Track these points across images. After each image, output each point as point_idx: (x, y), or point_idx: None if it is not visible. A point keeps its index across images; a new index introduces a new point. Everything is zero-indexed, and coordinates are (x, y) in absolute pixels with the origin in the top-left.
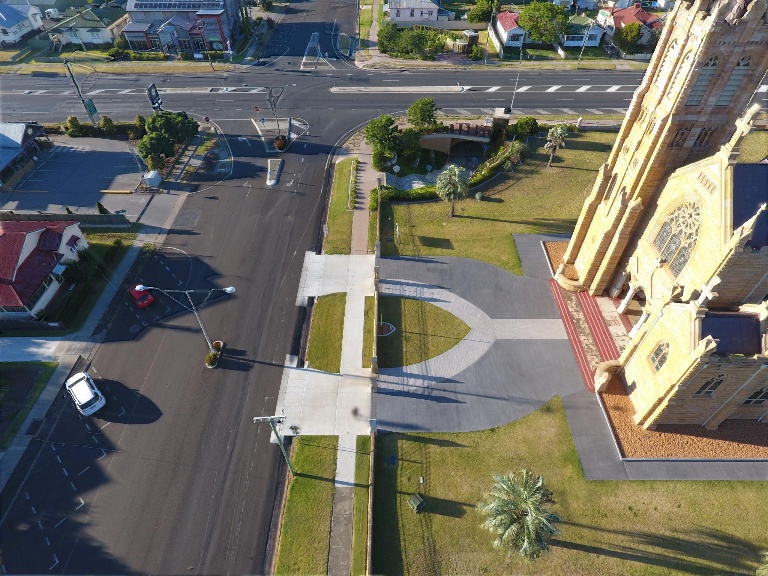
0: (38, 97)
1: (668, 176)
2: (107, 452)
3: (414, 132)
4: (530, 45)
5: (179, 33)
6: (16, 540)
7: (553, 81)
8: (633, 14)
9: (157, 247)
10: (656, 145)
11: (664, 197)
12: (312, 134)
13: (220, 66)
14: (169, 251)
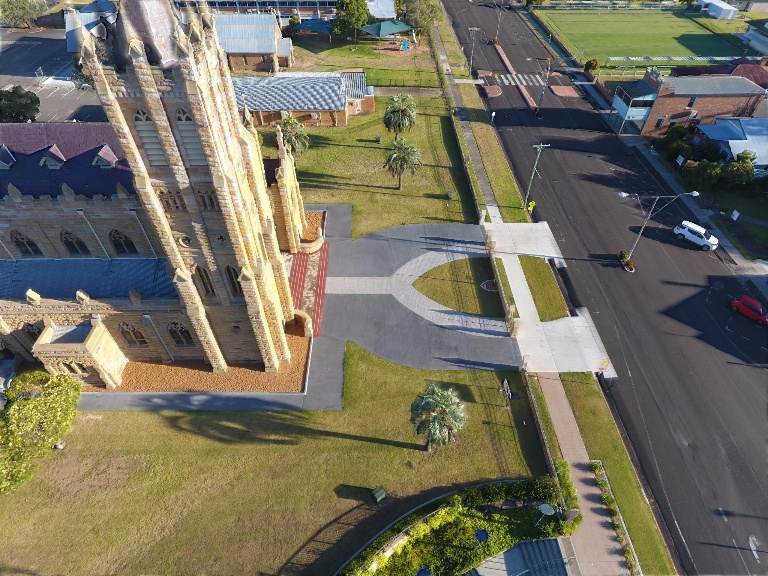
0: None
1: None
2: (644, 215)
3: None
4: None
5: None
6: (651, 189)
7: None
8: None
9: None
10: None
11: None
12: None
13: None
14: None
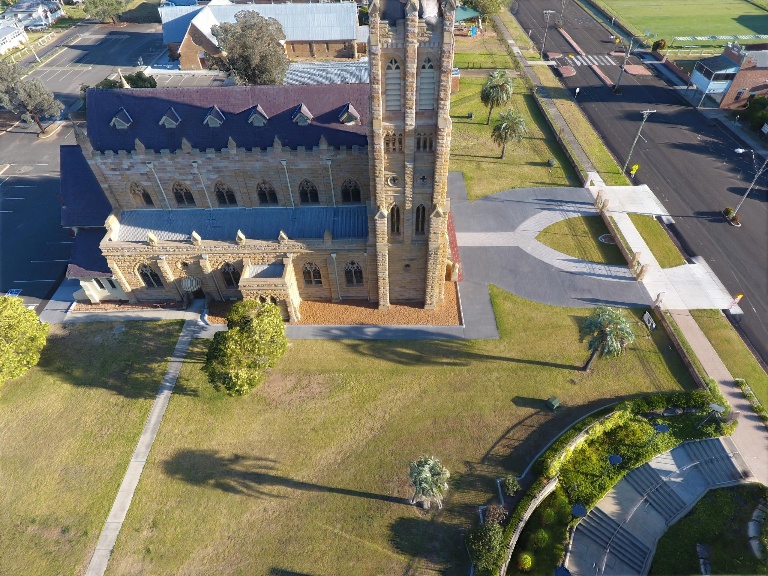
0: None
1: None
2: (739, 178)
3: (762, 575)
4: None
5: None
6: None
7: None
8: None
9: None
10: None
11: None
12: None
13: None
14: None
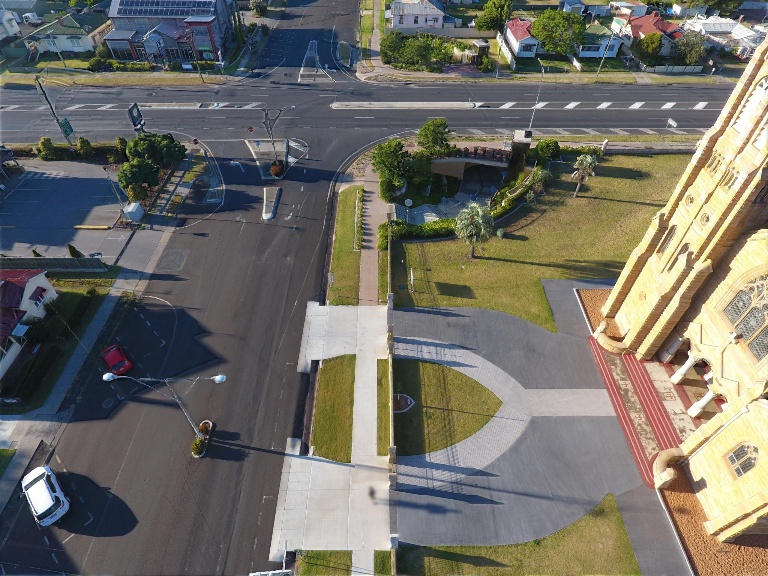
0: (10, 113)
1: (747, 237)
2: None
3: (426, 158)
4: (543, 55)
5: (166, 41)
6: None
7: (571, 96)
8: (652, 23)
9: (137, 296)
10: (737, 202)
11: (741, 261)
12: (312, 157)
13: (211, 78)
14: (151, 302)
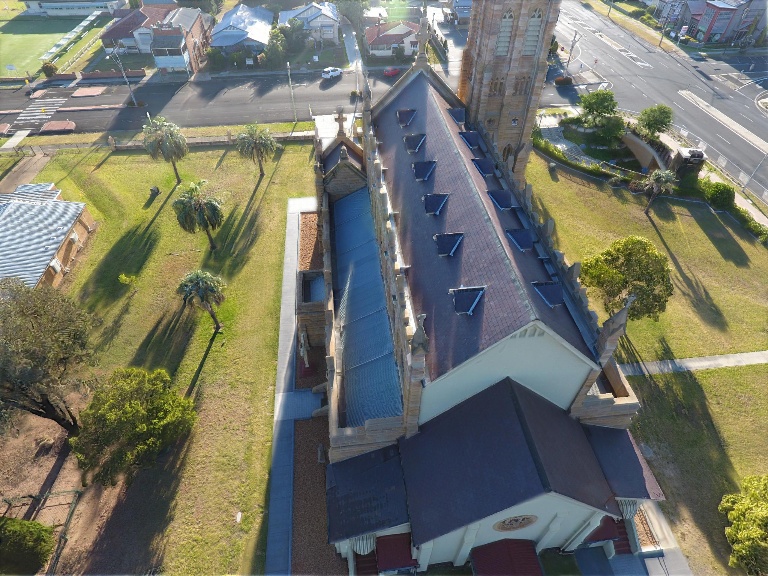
0: None
1: None
2: None
3: (616, 119)
4: None
5: (687, 14)
6: None
7: None
8: None
9: None
10: None
11: None
12: None
13: (669, 46)
14: None
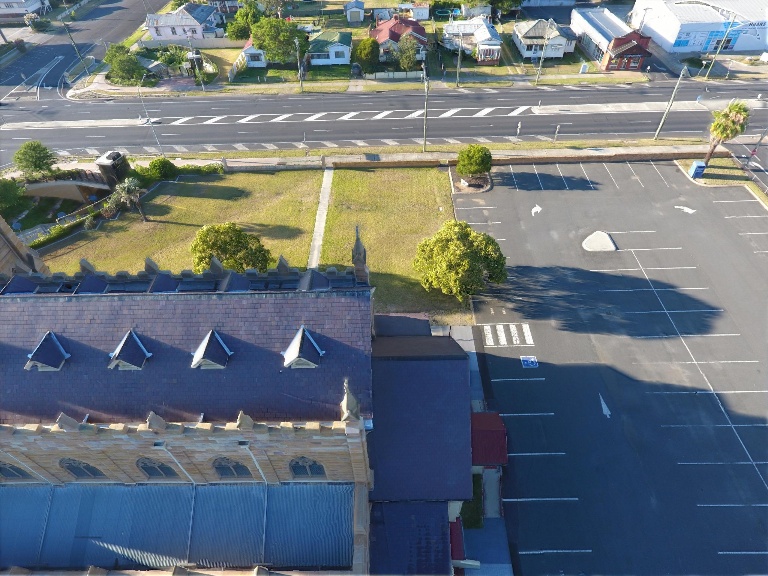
0: None
1: None
2: None
3: (2, 183)
4: (278, 65)
5: None
6: None
7: (258, 109)
8: (389, 27)
9: None
10: None
11: None
12: None
13: None
14: None
